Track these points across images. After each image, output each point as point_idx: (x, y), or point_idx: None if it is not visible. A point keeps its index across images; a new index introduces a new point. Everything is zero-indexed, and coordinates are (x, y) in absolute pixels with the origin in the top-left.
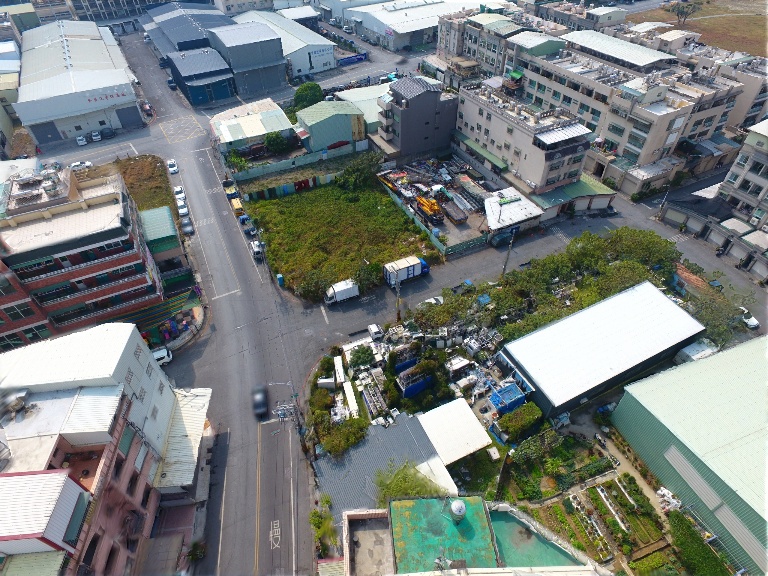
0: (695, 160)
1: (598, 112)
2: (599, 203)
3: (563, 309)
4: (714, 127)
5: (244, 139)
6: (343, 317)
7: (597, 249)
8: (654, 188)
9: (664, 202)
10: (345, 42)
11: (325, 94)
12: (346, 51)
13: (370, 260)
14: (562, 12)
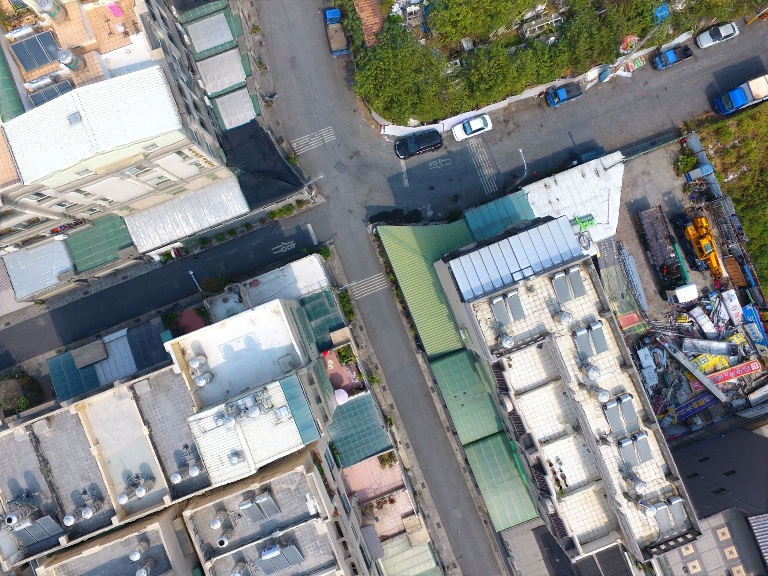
0: (179, 309)
1: None
2: None
3: None
4: None
5: None
6: None
7: None
8: None
9: None
10: None
11: None
12: None
13: None
14: None
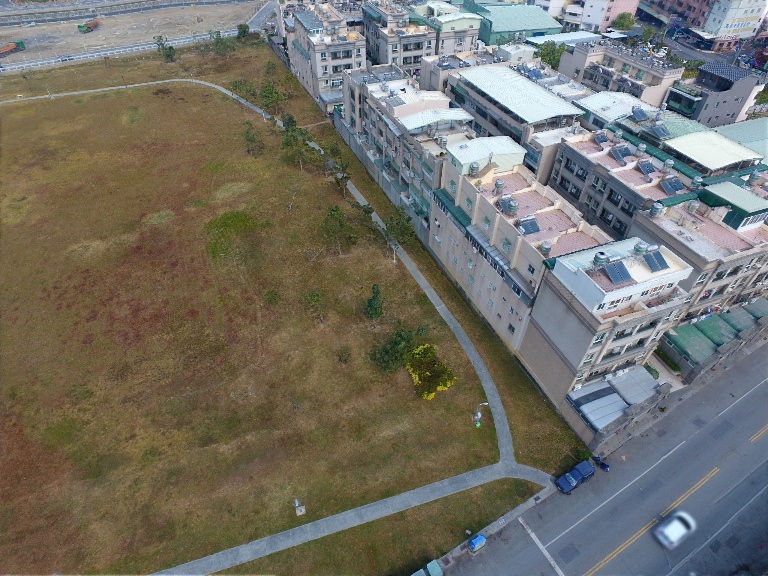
0: None
1: None
2: None
3: None
4: None
5: None
6: None
7: None
8: None
9: None
10: None
11: None
12: None
13: None
14: None
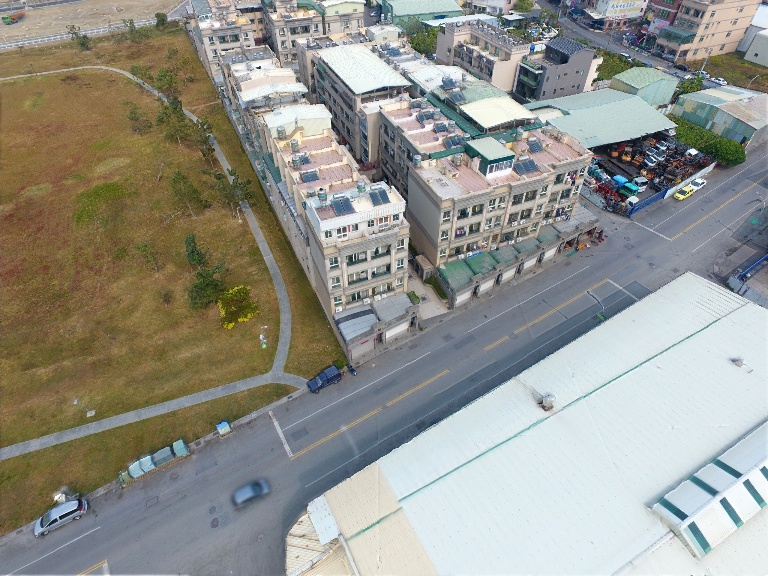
0: None
1: None
2: None
3: None
4: None
5: None
6: None
7: None
8: None
9: None
10: None
11: None
12: None
13: None
14: None
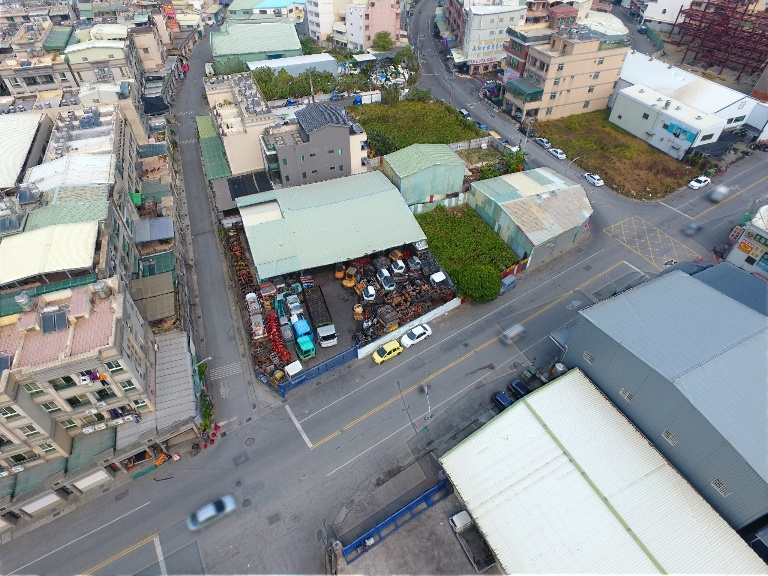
0: None
1: None
2: None
3: None
4: None
5: None
6: None
7: None
8: None
9: (171, 111)
10: None
11: None
12: None
13: None
14: None
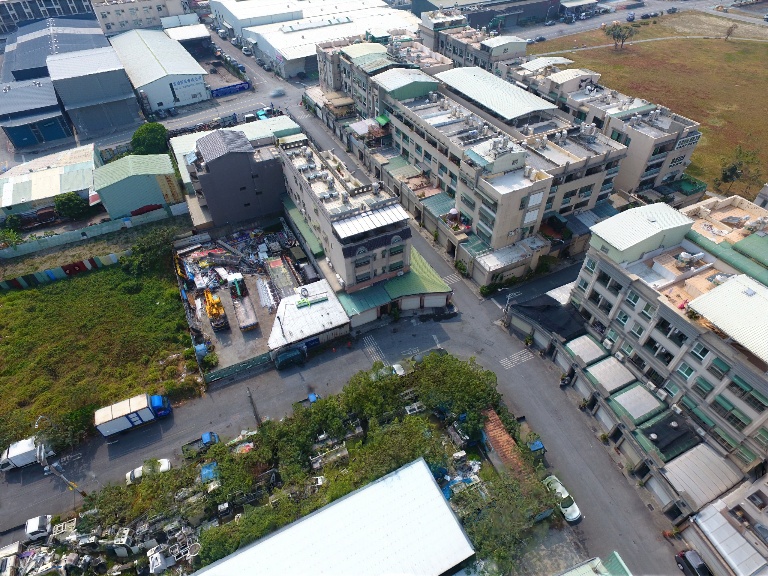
0: (564, 241)
1: (455, 176)
2: (434, 301)
3: (315, 489)
4: (595, 196)
5: (28, 202)
6: (17, 494)
7: (387, 389)
8: (512, 277)
9: (508, 306)
10: (233, 67)
11: (172, 136)
12: (234, 77)
13: (97, 394)
14: (459, 41)
